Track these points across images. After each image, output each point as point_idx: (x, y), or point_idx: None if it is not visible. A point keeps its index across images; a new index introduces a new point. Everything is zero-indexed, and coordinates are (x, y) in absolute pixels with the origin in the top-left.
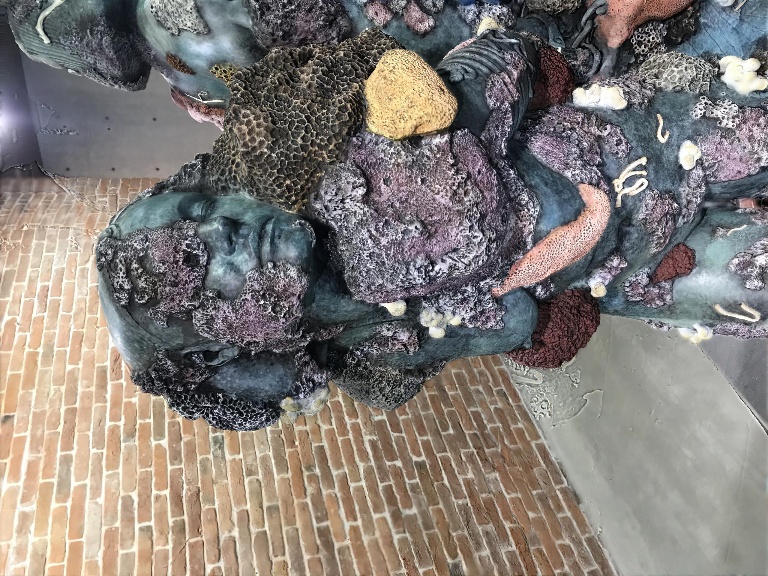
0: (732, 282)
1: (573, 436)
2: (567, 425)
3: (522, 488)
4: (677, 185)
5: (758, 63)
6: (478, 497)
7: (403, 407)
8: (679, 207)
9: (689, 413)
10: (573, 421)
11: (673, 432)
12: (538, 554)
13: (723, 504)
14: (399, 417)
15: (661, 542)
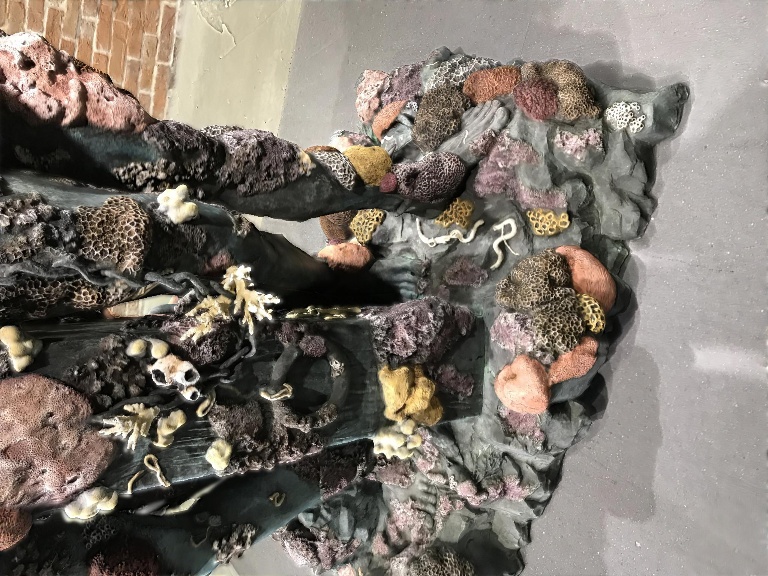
0: None
1: (198, 39)
2: (201, 22)
3: (117, 49)
4: None
5: None
6: (58, 37)
7: None
8: None
9: None
10: (206, 27)
11: None
12: None
13: None
14: None
15: None
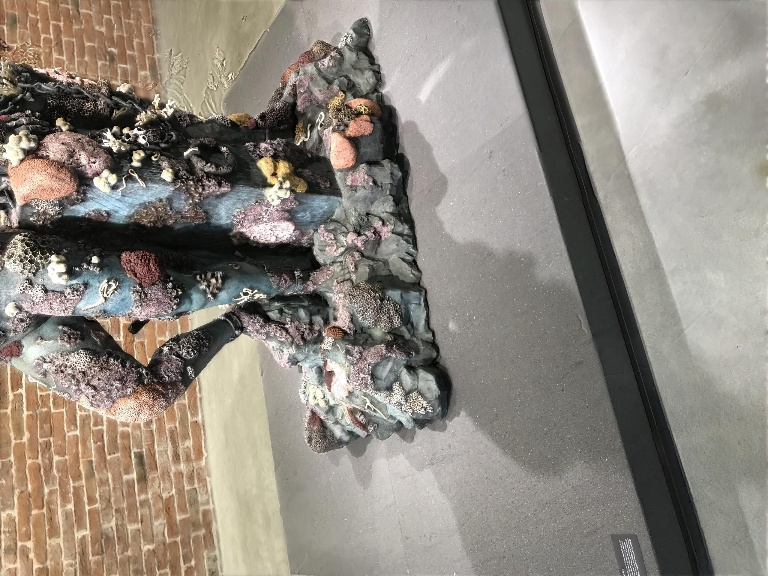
0: (34, 369)
1: None
2: None
3: None
4: (5, 322)
5: (63, 270)
6: None
7: None
8: (4, 333)
9: None
10: None
11: None
12: (140, 345)
13: (246, 352)
14: None
15: (219, 357)
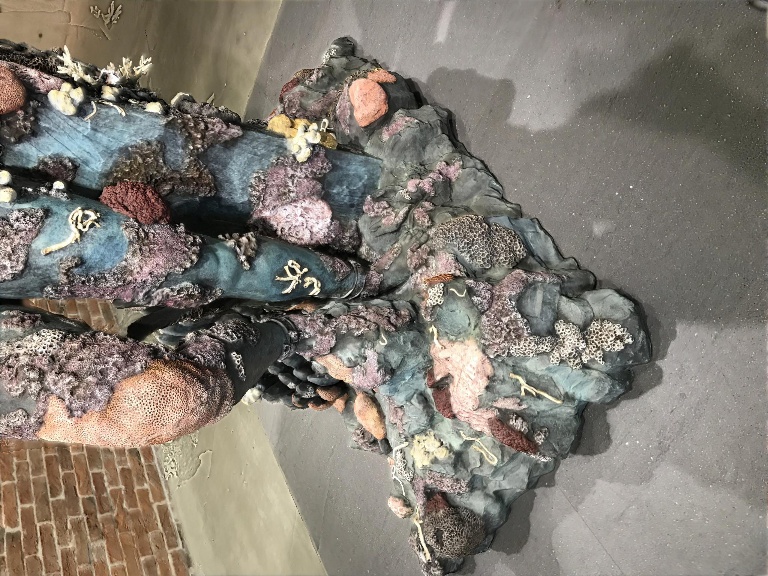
0: None
1: (190, 497)
2: (187, 485)
3: (130, 555)
4: None
5: (5, 177)
6: (75, 568)
7: (10, 471)
8: None
9: (264, 475)
10: (191, 481)
11: (254, 493)
12: None
13: (281, 562)
14: (1, 483)
15: None
